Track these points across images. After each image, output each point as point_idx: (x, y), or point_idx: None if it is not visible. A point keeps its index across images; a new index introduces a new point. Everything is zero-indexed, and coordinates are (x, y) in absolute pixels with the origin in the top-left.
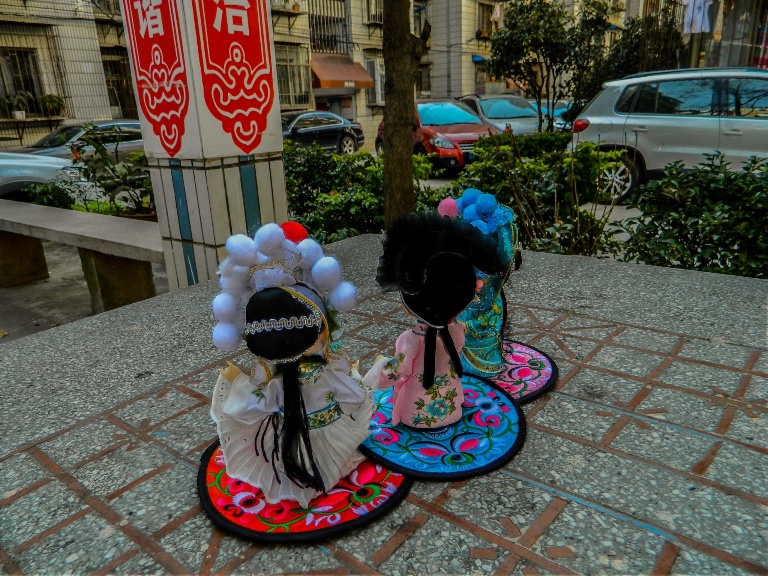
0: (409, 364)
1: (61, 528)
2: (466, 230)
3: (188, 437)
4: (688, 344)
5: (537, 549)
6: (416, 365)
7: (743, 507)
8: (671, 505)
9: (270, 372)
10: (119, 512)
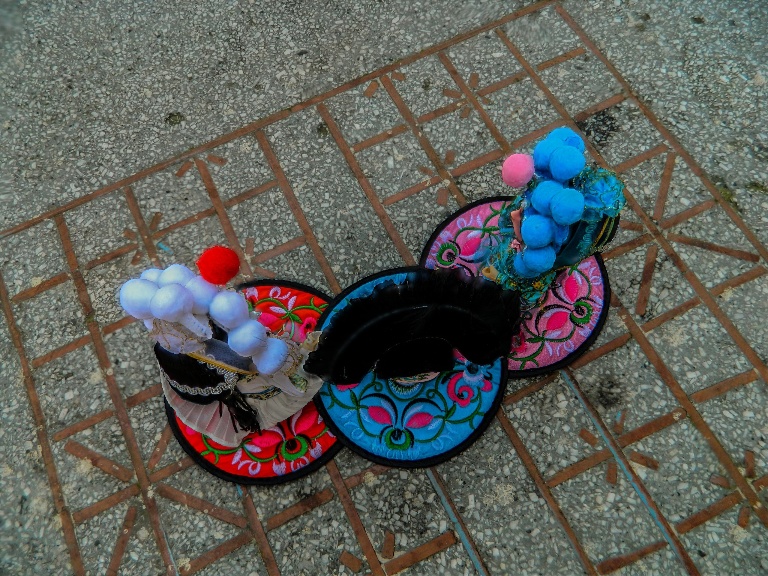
0: None
1: (66, 353)
2: (475, 298)
3: None
4: None
5: None
6: None
7: None
8: None
9: None
10: (109, 355)
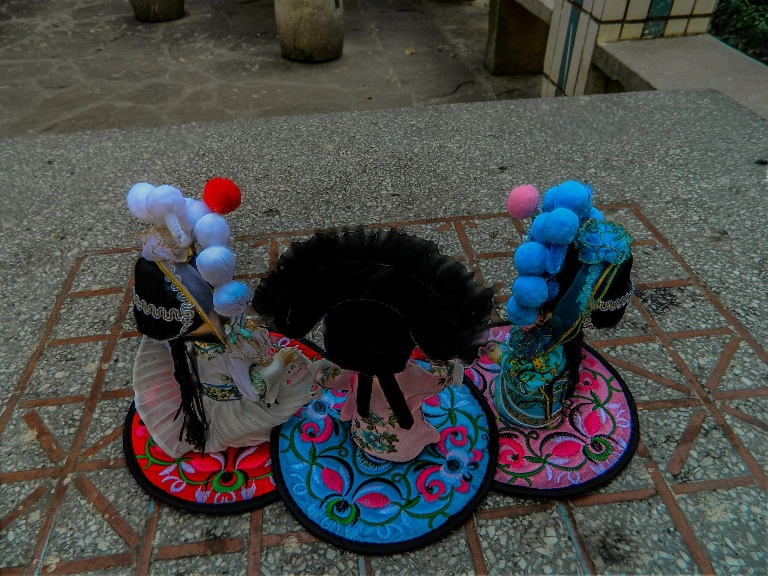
0: (340, 385)
1: (81, 342)
2: (441, 275)
3: None
4: None
5: None
6: None
7: None
8: None
9: None
10: (113, 354)
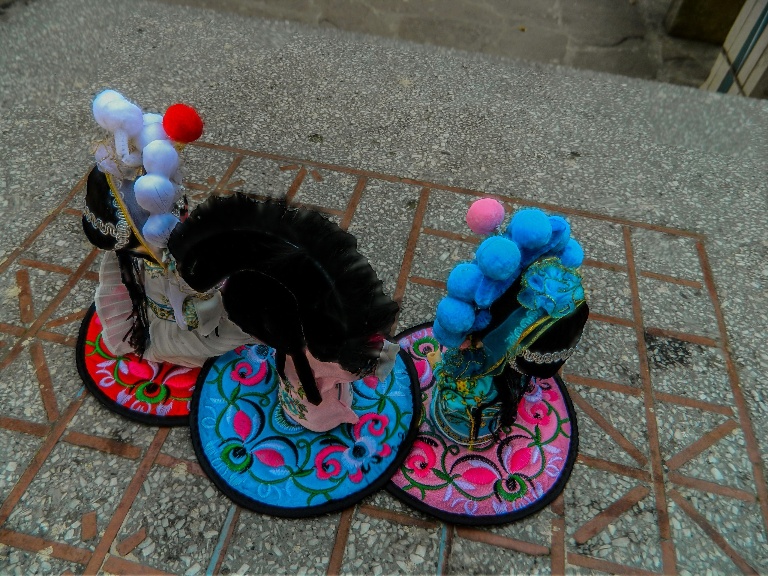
0: None
1: None
2: (347, 274)
3: None
4: None
5: None
6: None
7: None
8: None
9: None
10: None
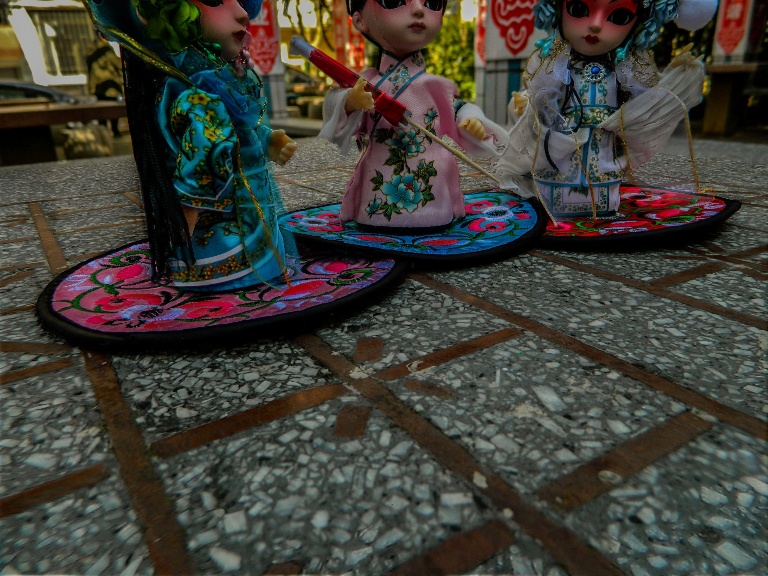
0: None
1: None
2: None
3: None
4: None
5: None
6: None
7: None
8: None
9: None
10: None
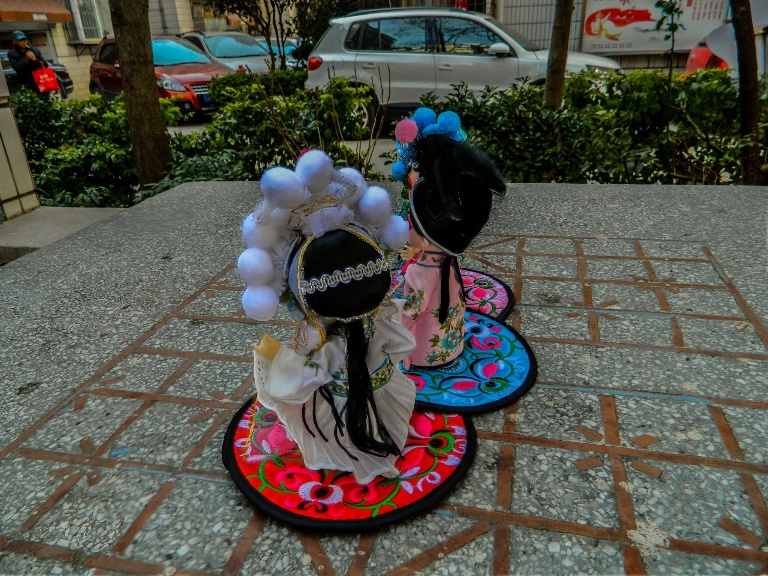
0: None
1: None
2: (464, 148)
3: (167, 445)
4: (584, 244)
5: (626, 444)
6: (431, 300)
7: (730, 363)
8: (685, 376)
9: (325, 335)
10: (151, 561)
